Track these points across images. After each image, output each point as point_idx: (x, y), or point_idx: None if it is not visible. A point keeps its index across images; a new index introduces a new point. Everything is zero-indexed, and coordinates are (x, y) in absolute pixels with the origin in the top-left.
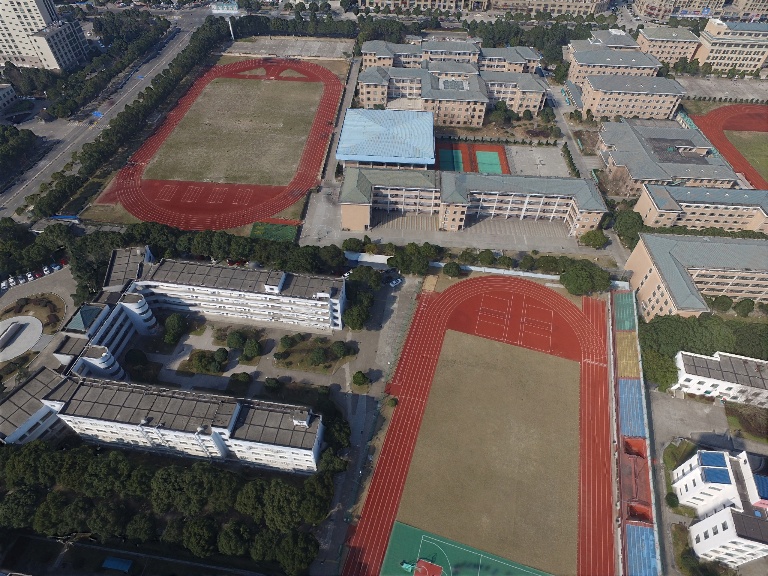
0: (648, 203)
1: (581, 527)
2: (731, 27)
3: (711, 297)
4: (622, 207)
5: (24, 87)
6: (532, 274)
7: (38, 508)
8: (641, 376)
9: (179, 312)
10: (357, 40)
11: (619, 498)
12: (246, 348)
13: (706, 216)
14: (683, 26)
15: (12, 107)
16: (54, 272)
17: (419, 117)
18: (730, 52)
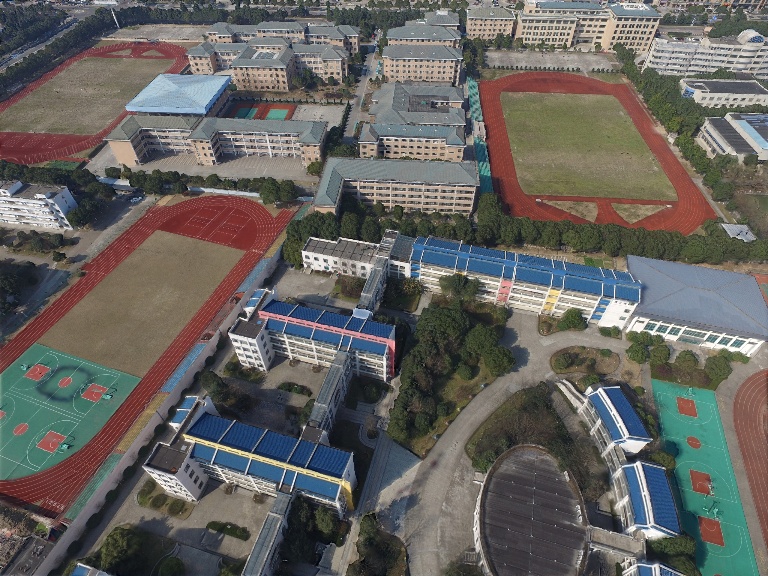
0: None
1: (170, 348)
2: (541, 6)
3: (385, 209)
4: None
5: None
6: (249, 193)
7: None
8: (274, 255)
9: None
10: None
11: None
12: None
13: (407, 149)
14: None
15: None
16: None
17: (215, 79)
18: (540, 28)
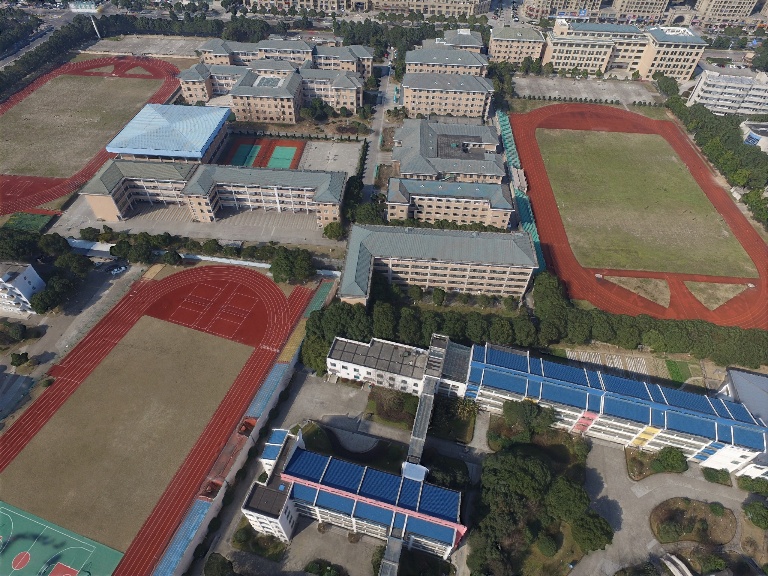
0: None
1: (161, 502)
2: (574, 27)
3: None
4: None
5: None
6: (256, 264)
7: None
8: (291, 360)
9: None
10: None
11: None
12: None
13: (443, 209)
14: None
15: None
16: None
17: (212, 112)
18: (573, 52)
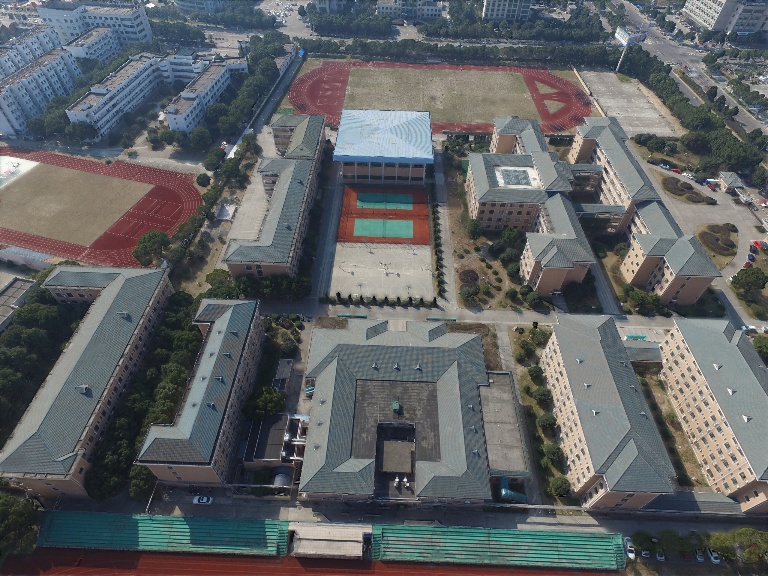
0: None
1: None
2: None
3: None
4: None
5: None
6: None
7: None
8: None
9: None
10: None
11: None
12: None
13: None
14: None
15: None
16: None
17: (417, 148)
18: None
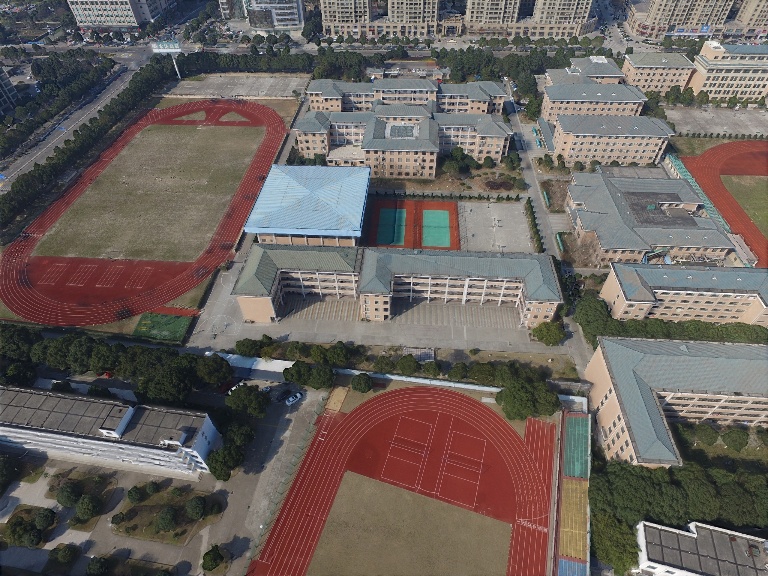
0: (616, 287)
1: None
2: (730, 50)
3: (694, 419)
4: (590, 283)
5: None
6: (465, 385)
7: None
8: (587, 559)
9: (15, 448)
10: (313, 75)
11: None
12: (76, 510)
13: (689, 304)
14: (679, 47)
15: None
16: None
17: (353, 175)
18: (730, 79)
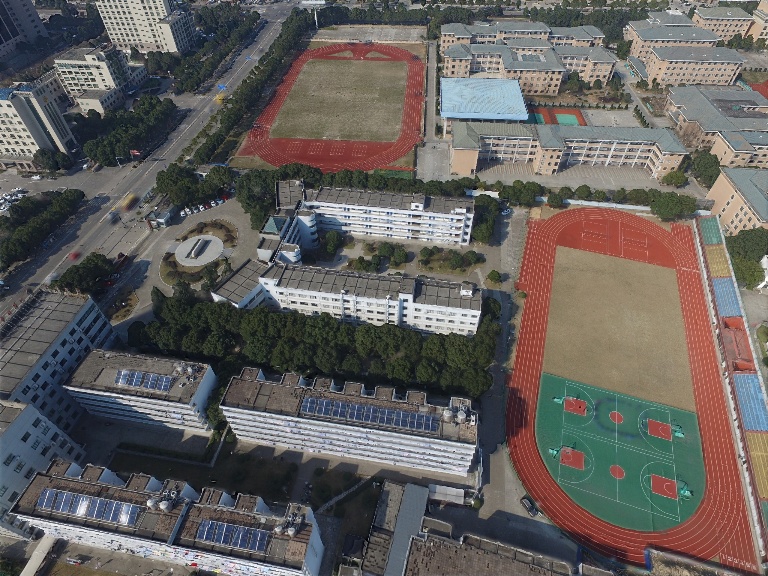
0: (723, 147)
1: (694, 378)
2: None
3: None
4: (695, 156)
5: (152, 67)
6: (624, 205)
7: (274, 349)
8: (733, 275)
9: None
10: (429, 26)
11: (724, 359)
12: (396, 254)
13: None
14: None
15: (145, 84)
16: (219, 205)
17: (507, 83)
18: None
